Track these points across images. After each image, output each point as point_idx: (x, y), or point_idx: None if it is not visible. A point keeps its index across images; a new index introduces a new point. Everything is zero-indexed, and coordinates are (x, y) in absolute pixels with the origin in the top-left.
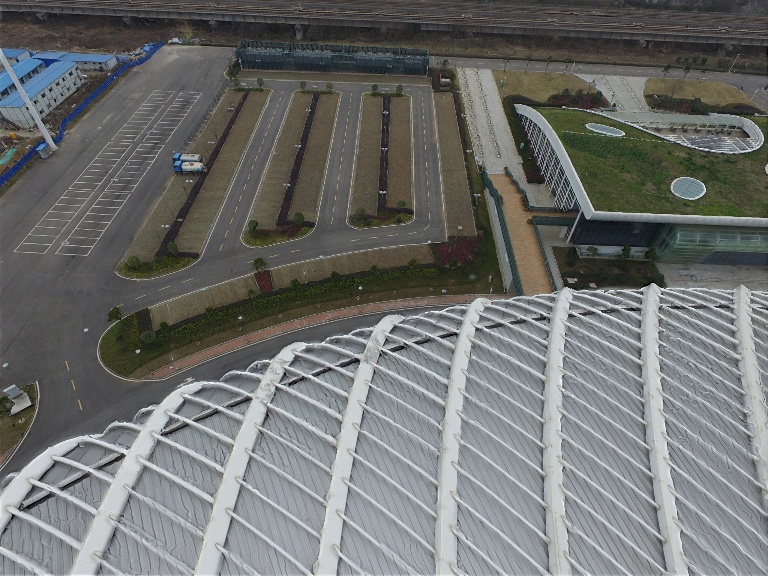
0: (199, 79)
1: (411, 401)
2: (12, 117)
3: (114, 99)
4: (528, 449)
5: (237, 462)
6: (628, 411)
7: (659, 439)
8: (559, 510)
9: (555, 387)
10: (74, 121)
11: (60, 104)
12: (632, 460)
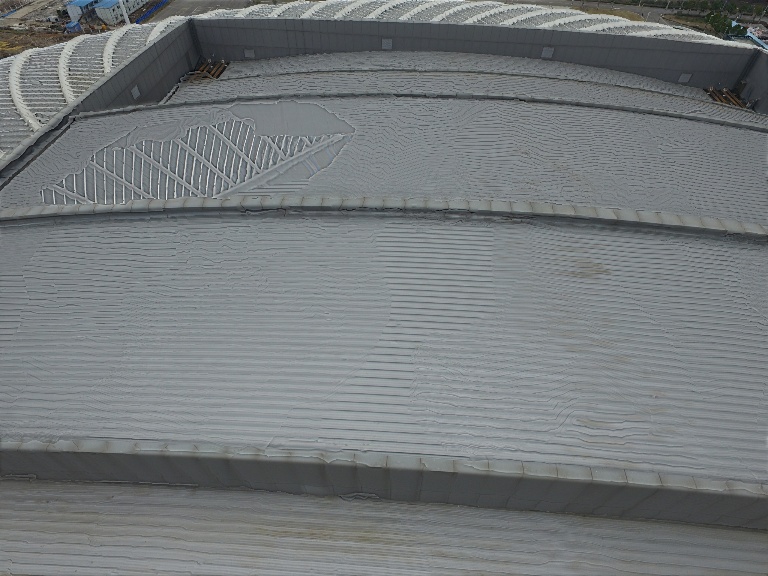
0: (230, 1)
1: (312, 3)
2: (103, 16)
3: (170, 11)
4: (345, 5)
5: (252, 8)
6: (384, 3)
7: (389, 4)
8: (347, 8)
9: (363, 1)
10: (144, 21)
11: (133, 13)
12: (377, 6)
